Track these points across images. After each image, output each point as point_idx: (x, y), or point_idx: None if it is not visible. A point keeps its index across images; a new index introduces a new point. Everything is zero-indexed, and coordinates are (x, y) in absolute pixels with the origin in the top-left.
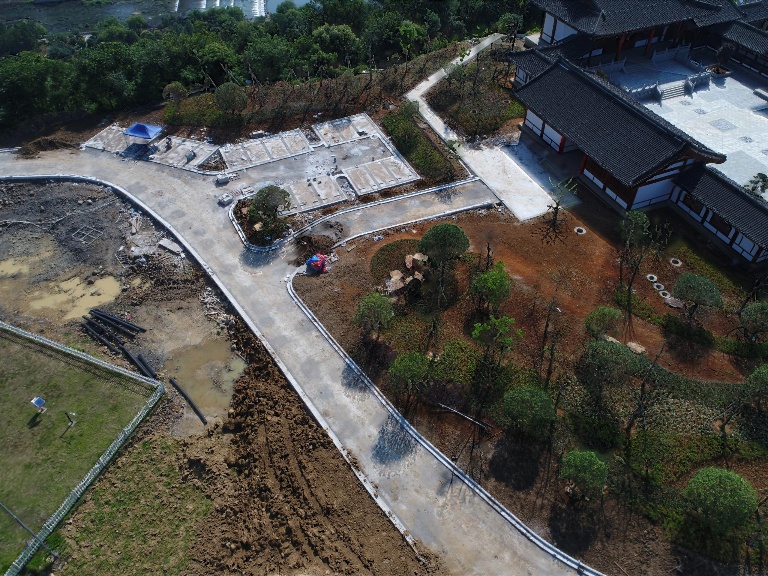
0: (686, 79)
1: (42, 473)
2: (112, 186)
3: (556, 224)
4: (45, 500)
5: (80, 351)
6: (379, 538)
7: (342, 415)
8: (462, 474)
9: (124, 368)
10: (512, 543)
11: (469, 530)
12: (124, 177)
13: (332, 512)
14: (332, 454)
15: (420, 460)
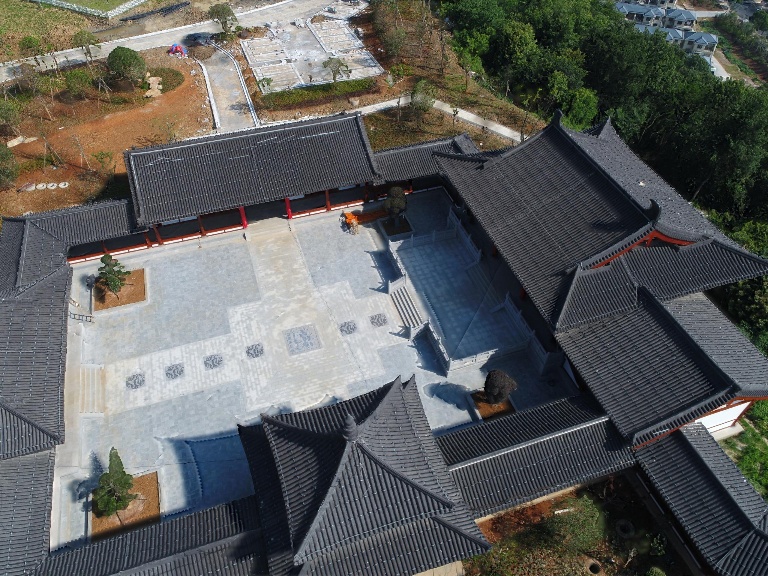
0: None
1: (86, 1)
2: None
3: None
4: (71, 3)
5: None
6: None
7: None
8: None
9: (124, 3)
10: None
11: None
12: None
13: None
14: None
15: (5, 78)
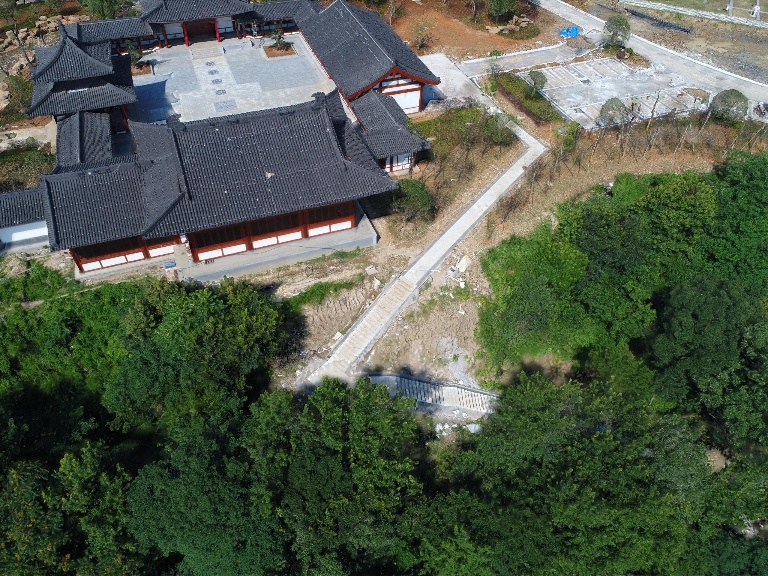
0: None
1: None
2: (765, 84)
3: None
4: None
5: (670, 6)
6: None
7: None
8: None
9: None
10: None
11: None
12: (765, 92)
13: None
14: None
15: None
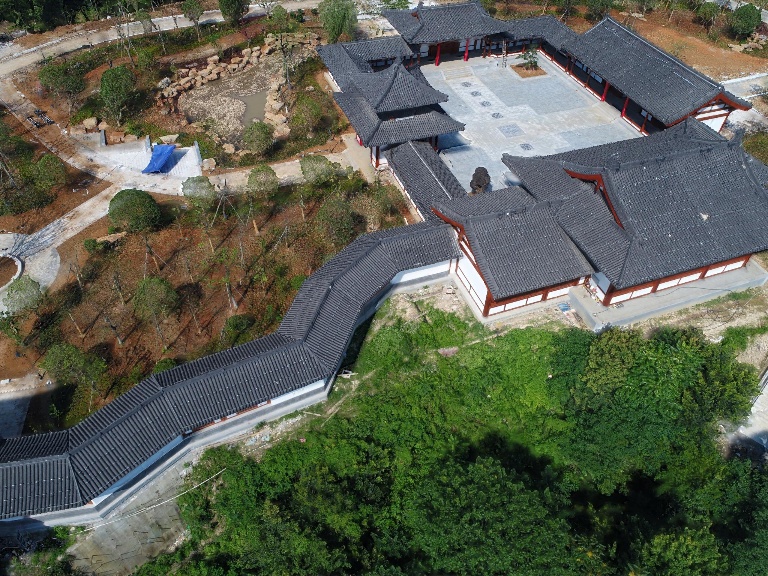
0: None
1: None
2: None
3: None
4: None
5: None
6: None
7: None
8: None
9: None
10: None
11: None
12: None
13: None
14: (748, 2)
15: (711, 1)
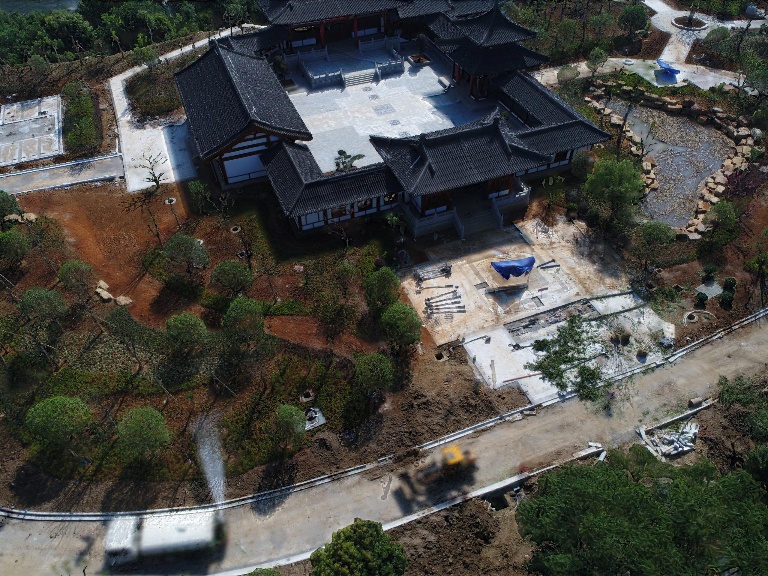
0: (375, 67)
1: None
2: None
3: (152, 195)
4: None
5: None
6: None
7: None
8: None
9: None
10: None
11: None
12: None
13: None
14: None
15: None
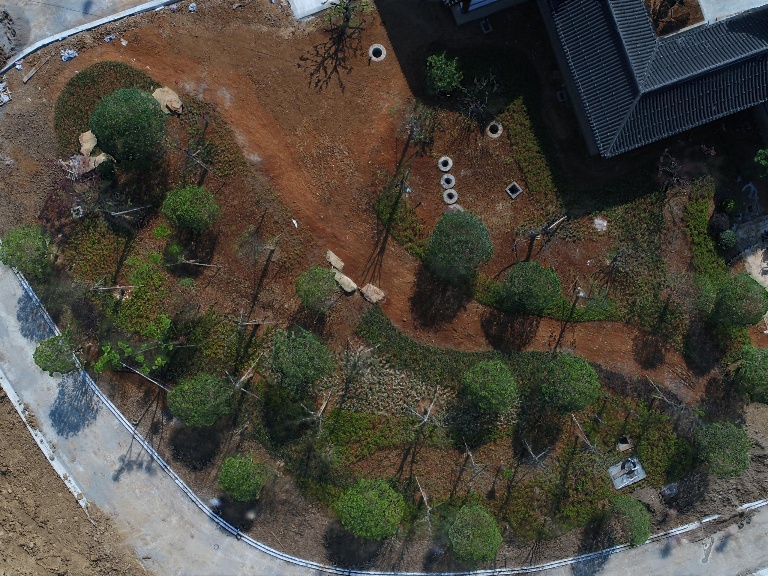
0: None
1: None
2: None
3: (343, 37)
4: None
5: None
6: (54, 499)
7: (18, 361)
8: (141, 440)
9: None
10: (181, 509)
11: (142, 495)
12: None
13: (8, 473)
14: (7, 410)
15: (101, 420)
